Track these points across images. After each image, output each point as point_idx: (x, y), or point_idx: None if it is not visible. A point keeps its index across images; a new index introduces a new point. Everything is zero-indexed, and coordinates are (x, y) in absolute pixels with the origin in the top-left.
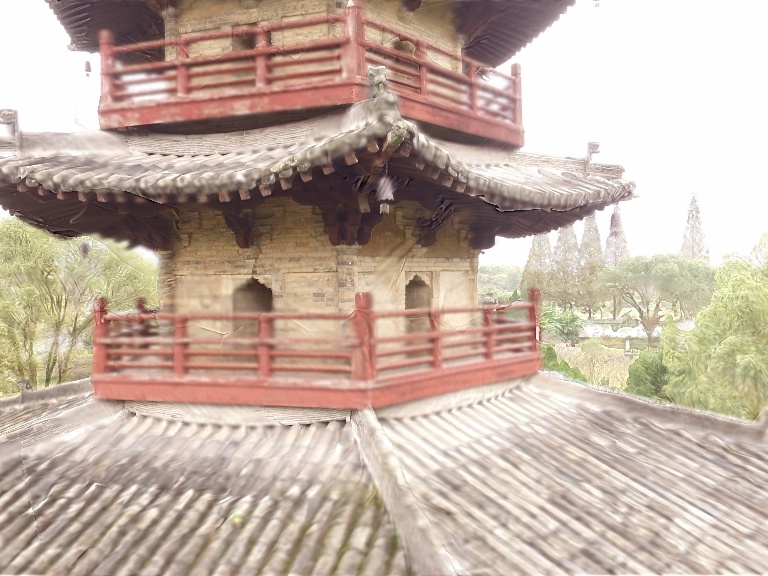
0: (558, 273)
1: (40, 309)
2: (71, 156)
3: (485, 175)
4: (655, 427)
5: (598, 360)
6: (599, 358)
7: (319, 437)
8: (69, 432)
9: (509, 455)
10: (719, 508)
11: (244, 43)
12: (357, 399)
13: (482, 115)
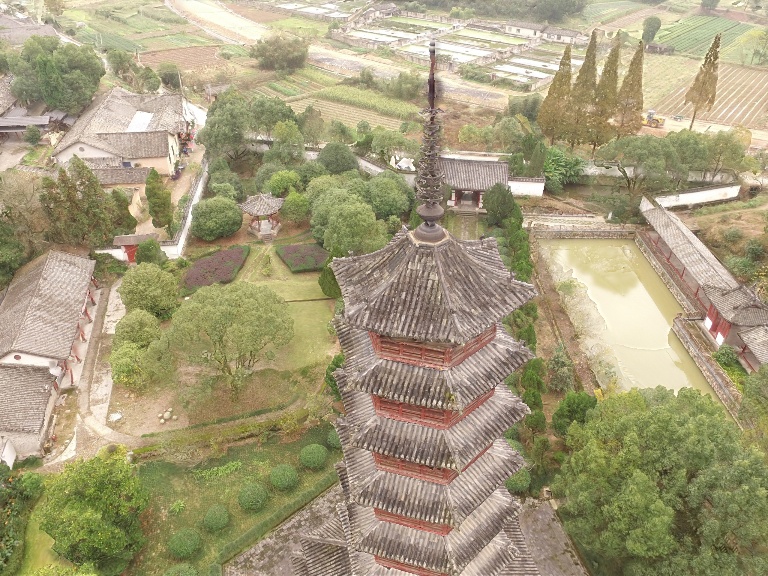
0: (574, 106)
1: (227, 340)
2: None
3: (476, 575)
4: None
5: (568, 296)
6: (569, 296)
7: None
8: None
9: None
10: None
11: None
12: None
13: None
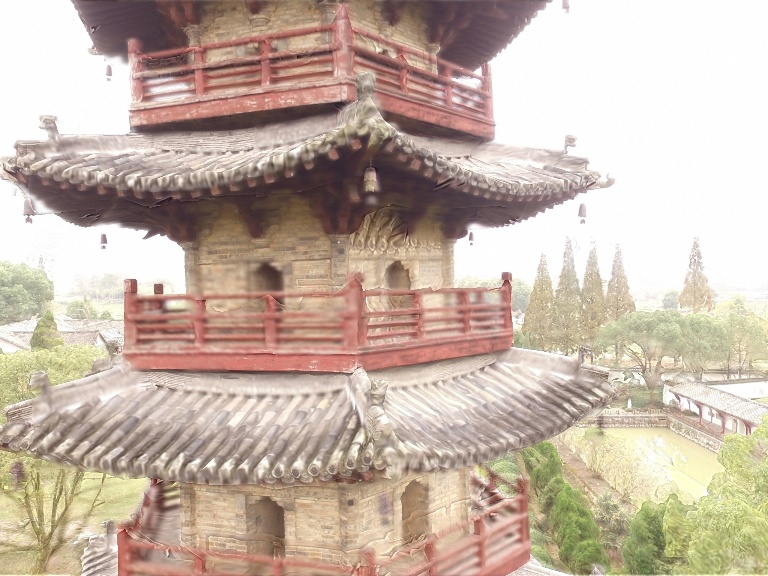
0: (560, 316)
1: None
2: None
3: None
4: None
5: (600, 448)
6: (601, 447)
7: None
8: None
9: None
10: None
11: (257, 506)
12: None
13: (490, 559)
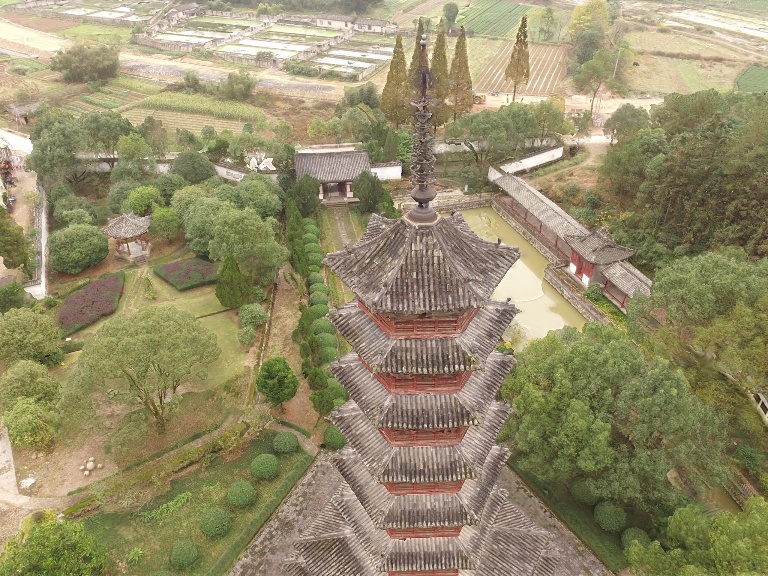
0: (411, 91)
1: None
2: (393, 553)
3: None
4: (507, 533)
5: None
6: None
7: None
8: None
9: (481, 568)
10: (519, 564)
11: None
12: (456, 575)
13: None
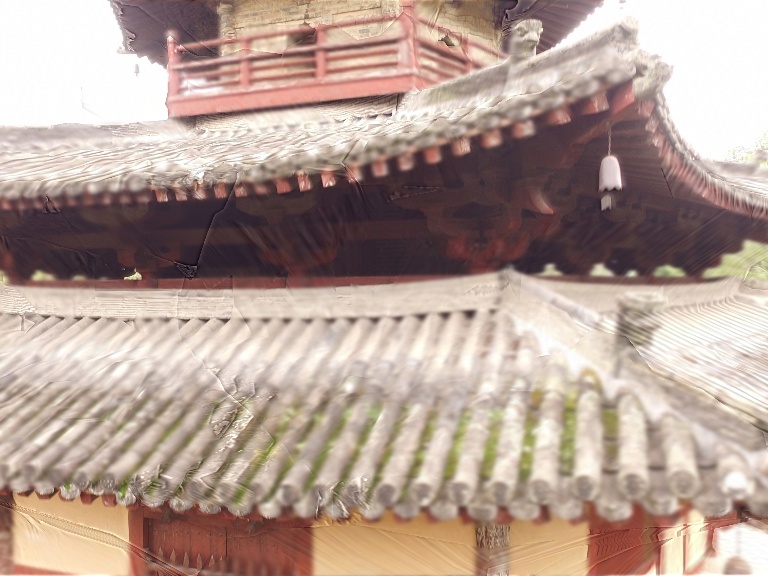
0: None
1: None
2: None
3: None
4: None
5: None
6: None
7: (370, 121)
8: (150, 136)
9: None
10: None
11: None
12: (403, 84)
13: None
